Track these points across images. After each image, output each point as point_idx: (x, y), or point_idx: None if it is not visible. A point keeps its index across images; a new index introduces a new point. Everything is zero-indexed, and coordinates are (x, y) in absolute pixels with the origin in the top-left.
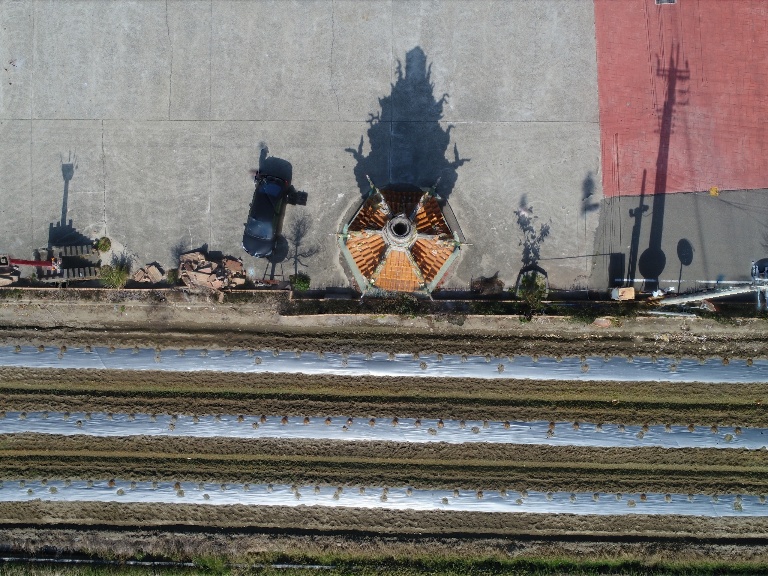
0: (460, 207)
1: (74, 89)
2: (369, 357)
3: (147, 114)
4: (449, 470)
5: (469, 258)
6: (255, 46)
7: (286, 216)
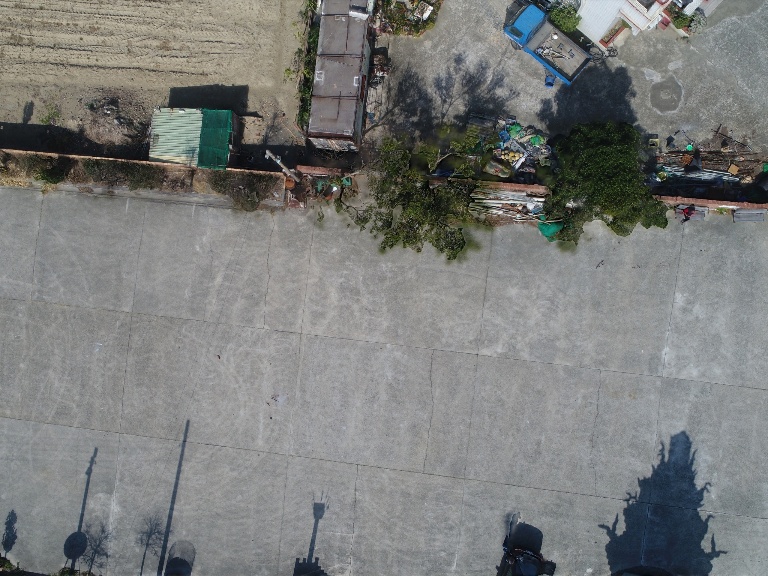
0: None
1: (333, 431)
2: None
3: (402, 464)
4: None
5: None
6: (517, 411)
7: None
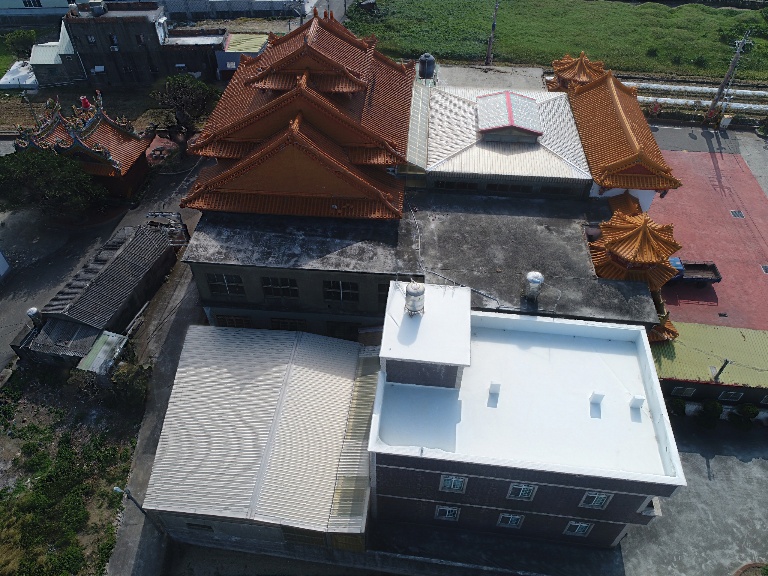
0: None
1: None
2: None
3: None
4: None
5: None
6: None
7: None
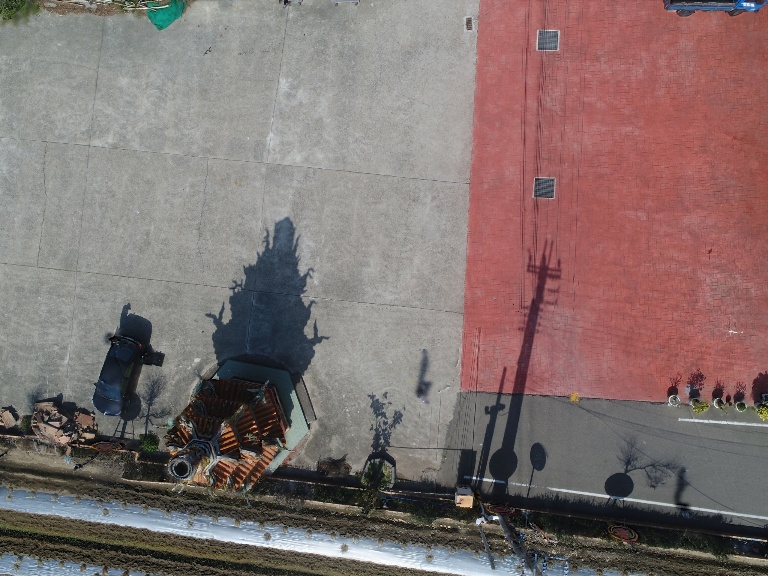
0: (314, 385)
1: None
2: (215, 521)
3: (16, 259)
4: None
5: (319, 437)
6: (127, 201)
7: (142, 375)
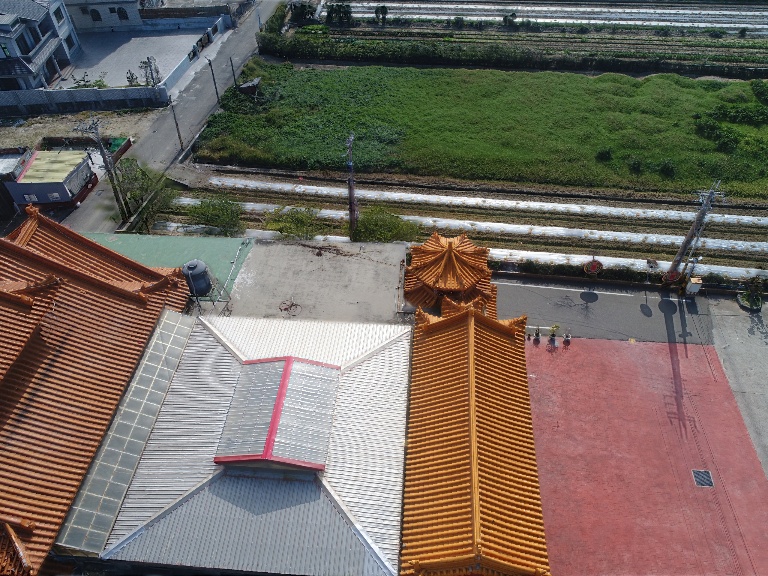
0: None
1: None
2: None
3: None
4: (762, 232)
5: None
6: None
7: None
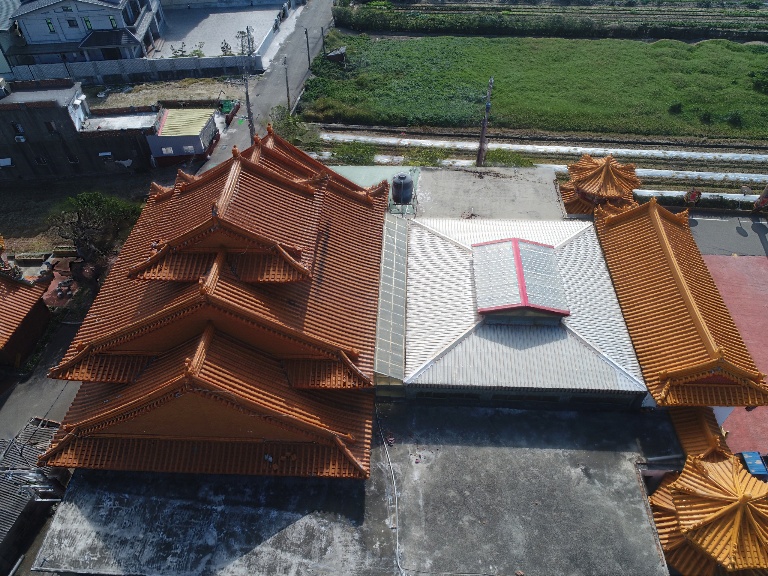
0: None
1: None
2: None
3: None
4: None
5: None
6: None
7: None
